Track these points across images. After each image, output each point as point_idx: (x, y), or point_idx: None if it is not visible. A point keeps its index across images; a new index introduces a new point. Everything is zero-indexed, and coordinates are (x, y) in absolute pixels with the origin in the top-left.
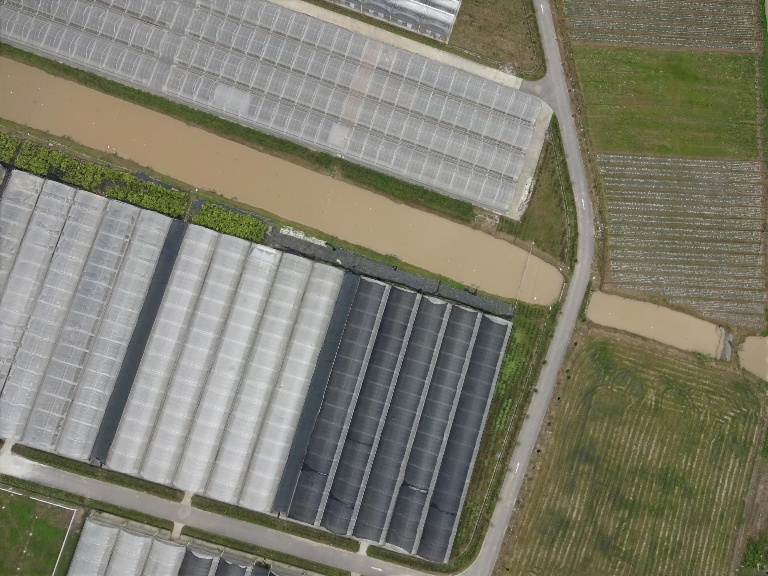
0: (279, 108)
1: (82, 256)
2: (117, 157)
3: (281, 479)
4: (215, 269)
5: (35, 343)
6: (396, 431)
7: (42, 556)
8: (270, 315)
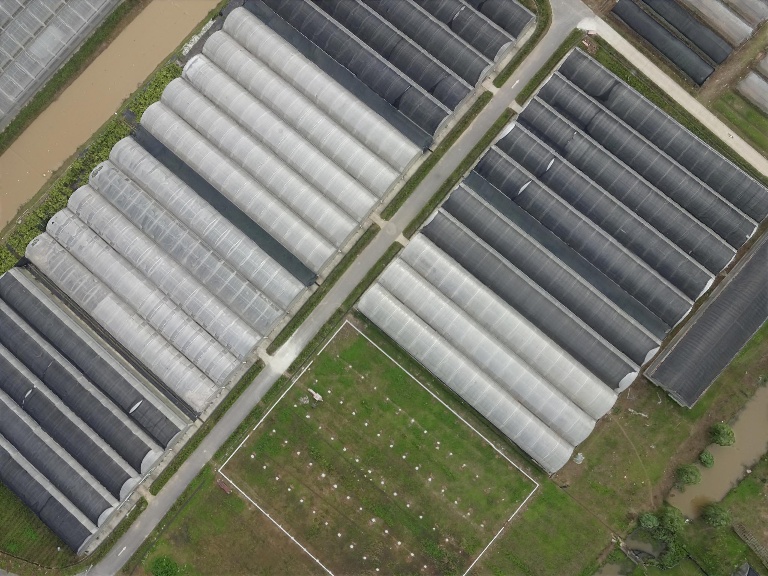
0: (73, 8)
1: (126, 224)
2: (57, 171)
3: (398, 130)
4: (189, 114)
5: (183, 289)
6: (400, 12)
7: (373, 364)
8: (250, 81)
